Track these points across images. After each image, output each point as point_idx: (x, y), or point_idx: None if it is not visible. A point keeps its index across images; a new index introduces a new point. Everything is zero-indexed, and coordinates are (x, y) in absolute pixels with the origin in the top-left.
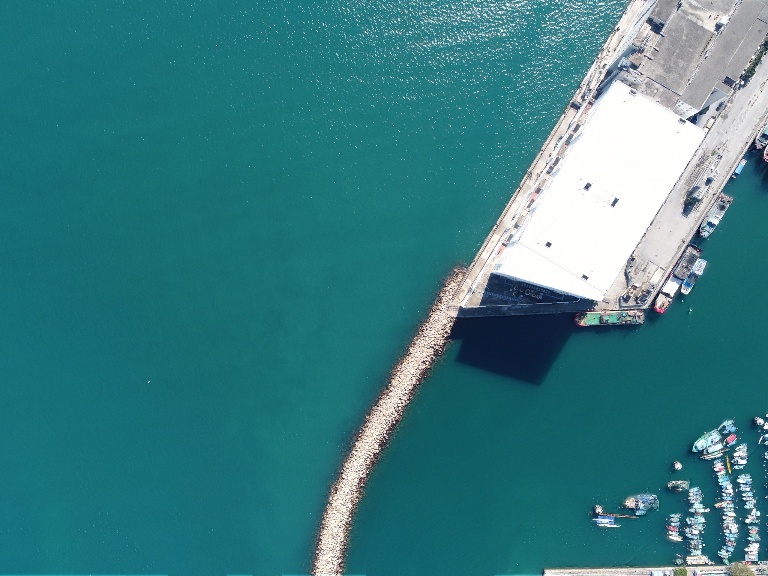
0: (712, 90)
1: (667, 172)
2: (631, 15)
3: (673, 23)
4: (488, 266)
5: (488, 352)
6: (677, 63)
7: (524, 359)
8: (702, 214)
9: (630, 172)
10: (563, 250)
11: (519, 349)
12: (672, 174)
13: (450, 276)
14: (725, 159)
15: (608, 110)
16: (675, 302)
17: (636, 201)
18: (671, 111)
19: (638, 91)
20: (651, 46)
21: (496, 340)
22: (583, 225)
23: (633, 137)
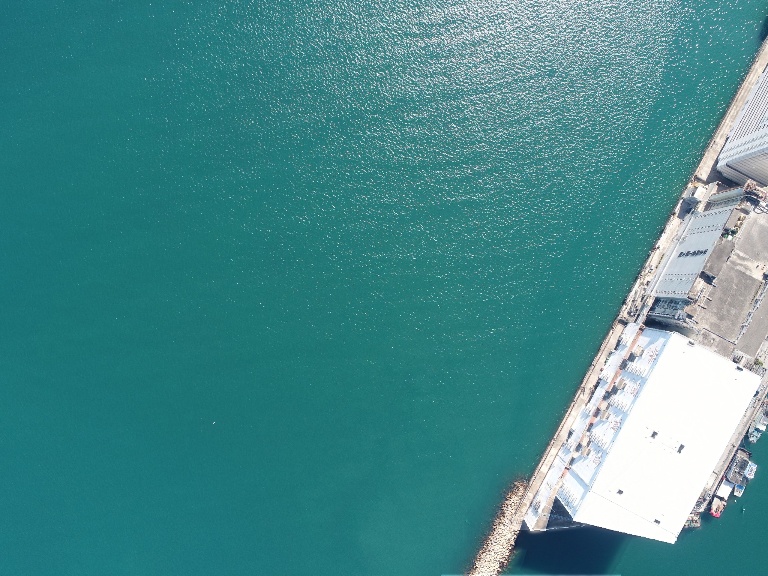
0: (765, 338)
1: (728, 418)
2: (670, 233)
3: (723, 274)
4: (552, 490)
5: (552, 561)
6: (729, 311)
7: (588, 566)
8: (749, 420)
9: (693, 419)
10: (634, 495)
11: (582, 556)
12: (733, 419)
13: (511, 489)
14: (767, 366)
15: (668, 360)
16: (728, 502)
17: (700, 445)
18: (728, 360)
19: (696, 342)
20: (704, 296)
21: (560, 550)
22: (652, 472)
23: (694, 387)
